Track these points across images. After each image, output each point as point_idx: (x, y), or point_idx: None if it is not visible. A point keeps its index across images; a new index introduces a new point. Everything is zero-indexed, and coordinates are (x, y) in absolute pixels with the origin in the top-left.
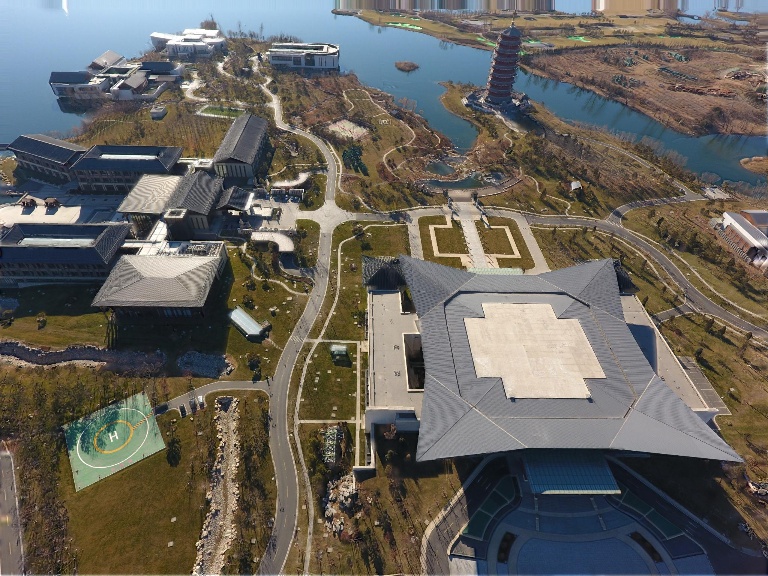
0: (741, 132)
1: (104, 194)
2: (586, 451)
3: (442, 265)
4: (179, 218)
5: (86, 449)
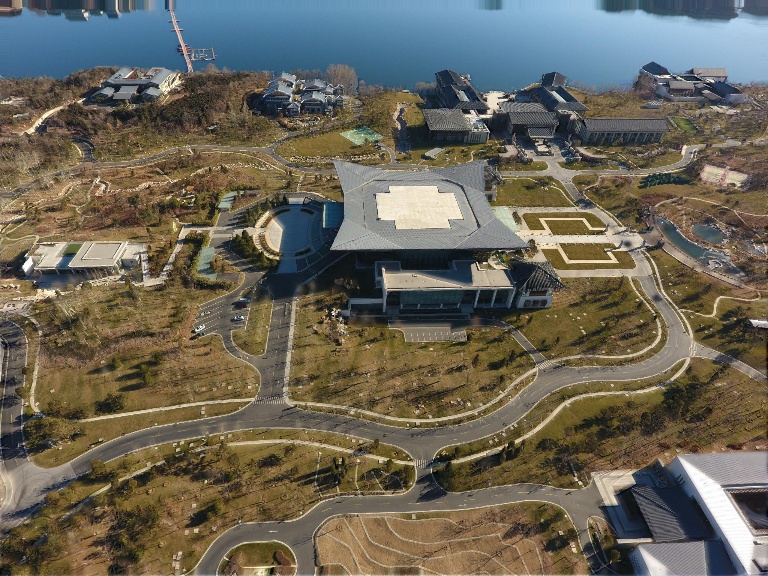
0: None
1: None
2: None
3: None
4: (496, 113)
5: None
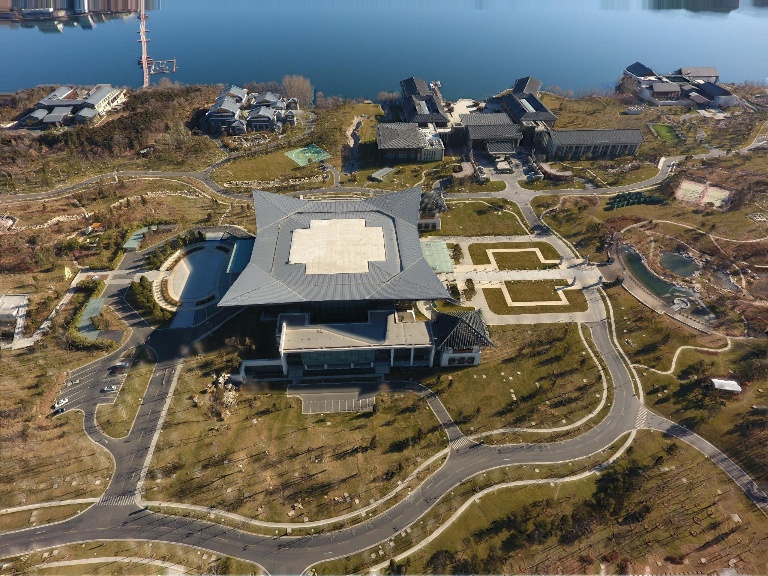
0: None
1: None
2: None
3: None
4: (454, 126)
5: (302, 150)
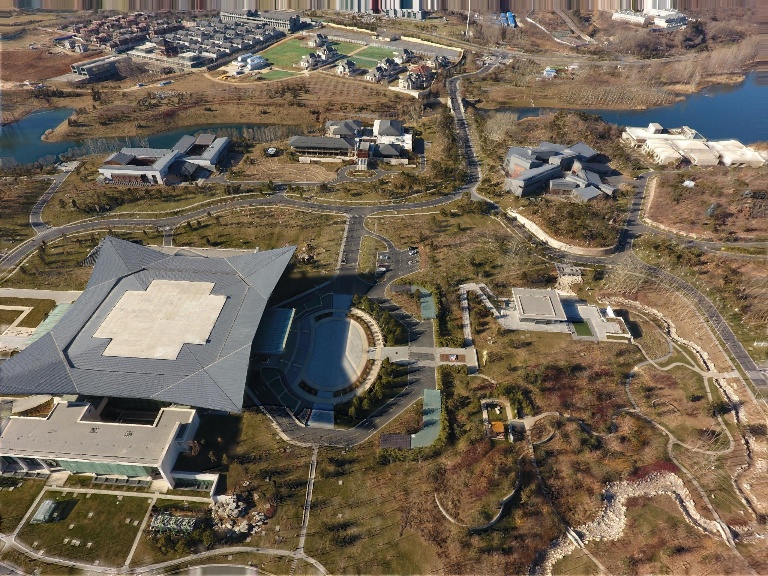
0: (7, 122)
1: None
2: (263, 315)
3: (14, 356)
4: None
5: None
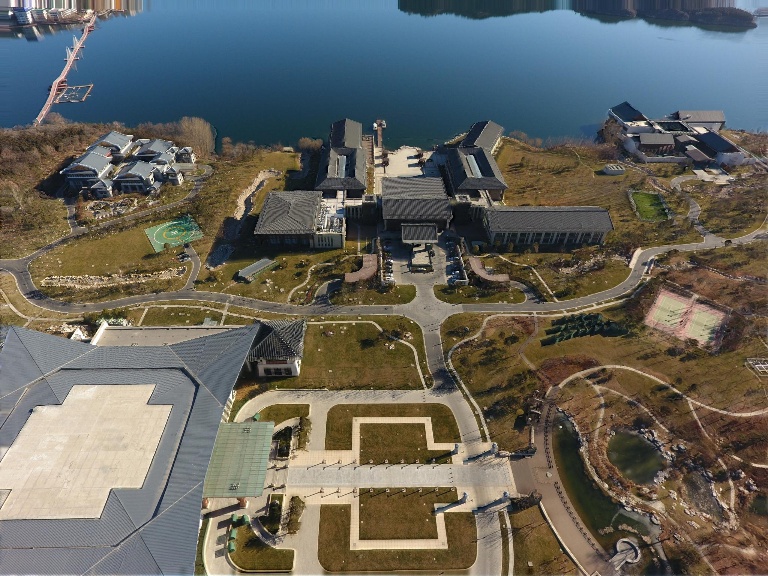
0: None
1: (443, 179)
2: None
3: None
4: (362, 201)
5: (170, 226)
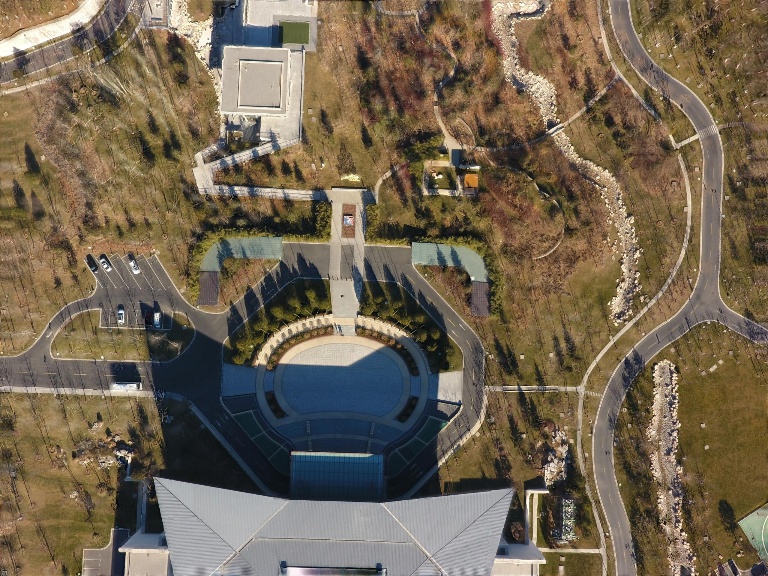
0: None
1: None
2: None
3: None
4: None
5: None
